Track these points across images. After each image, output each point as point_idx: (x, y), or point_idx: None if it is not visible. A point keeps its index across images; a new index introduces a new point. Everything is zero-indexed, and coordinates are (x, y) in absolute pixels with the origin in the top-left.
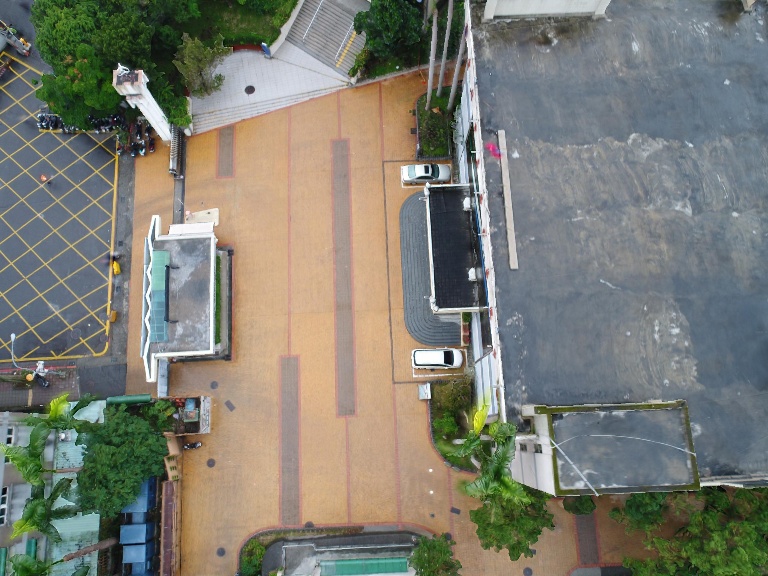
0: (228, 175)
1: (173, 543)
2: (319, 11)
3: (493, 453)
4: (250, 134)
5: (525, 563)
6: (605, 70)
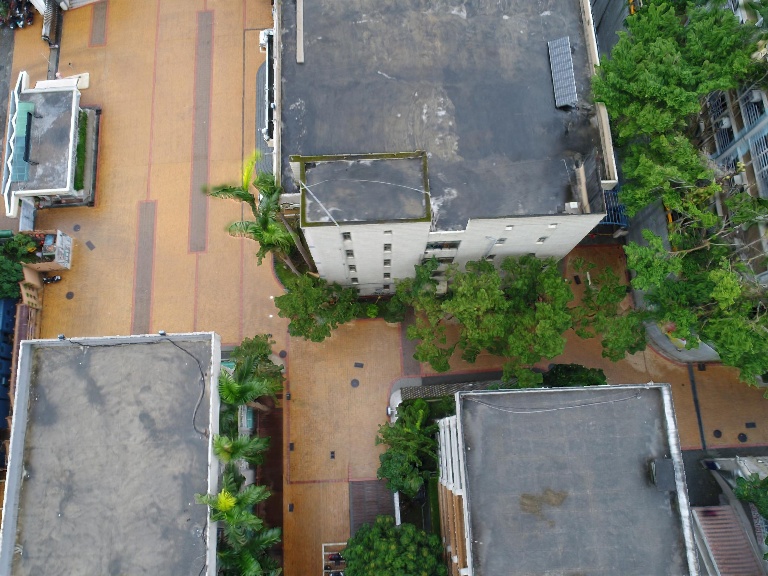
0: (100, 44)
1: None
2: None
3: None
4: (122, 8)
5: (353, 375)
6: None
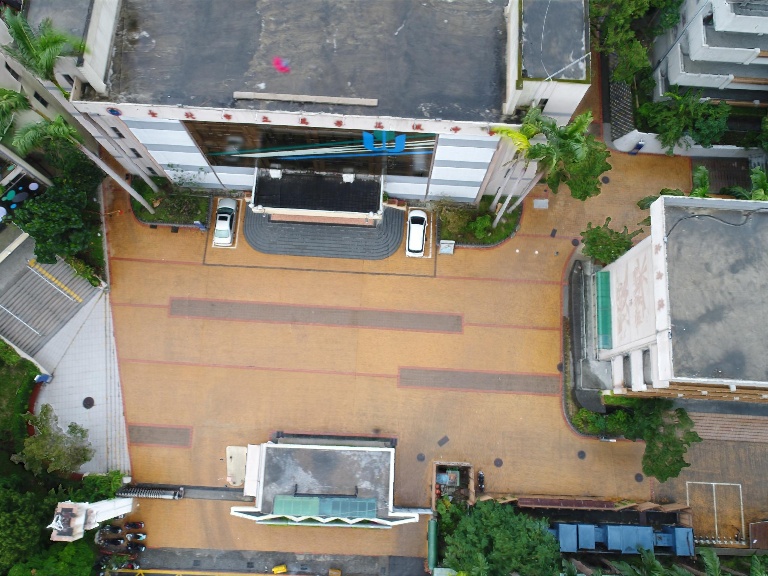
0: (189, 434)
1: None
2: (8, 312)
3: (507, 192)
4: (143, 407)
5: None
6: None
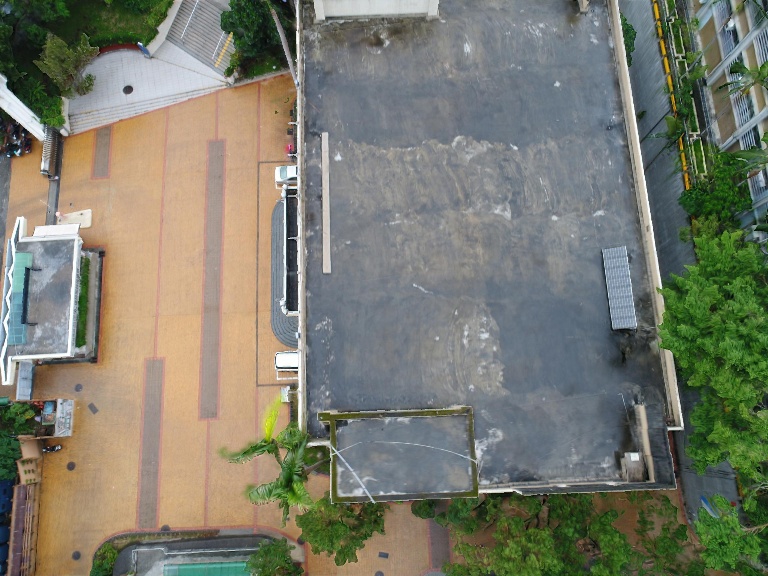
0: (103, 176)
1: (26, 547)
2: (197, 10)
3: None
4: (127, 134)
5: (377, 567)
6: (435, 72)
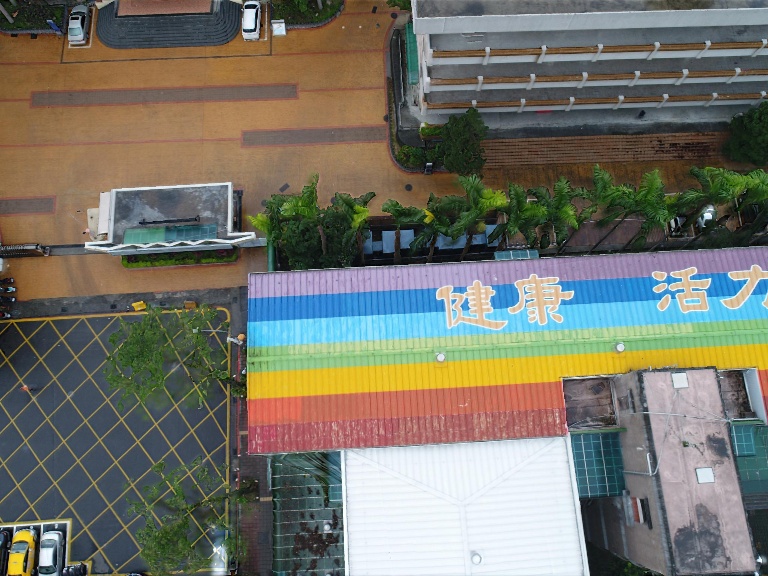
0: (52, 202)
1: None
2: None
3: None
4: (10, 183)
5: None
6: None
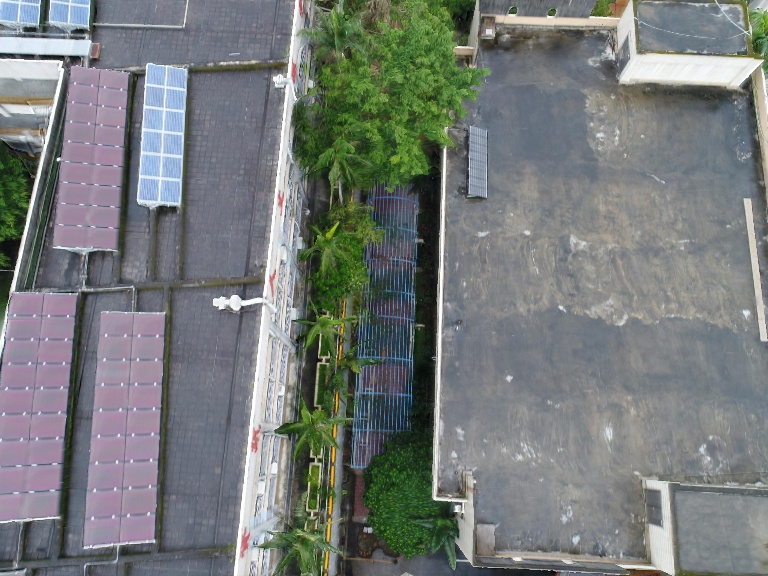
0: None
1: None
2: None
3: None
4: None
5: None
6: (647, 405)
